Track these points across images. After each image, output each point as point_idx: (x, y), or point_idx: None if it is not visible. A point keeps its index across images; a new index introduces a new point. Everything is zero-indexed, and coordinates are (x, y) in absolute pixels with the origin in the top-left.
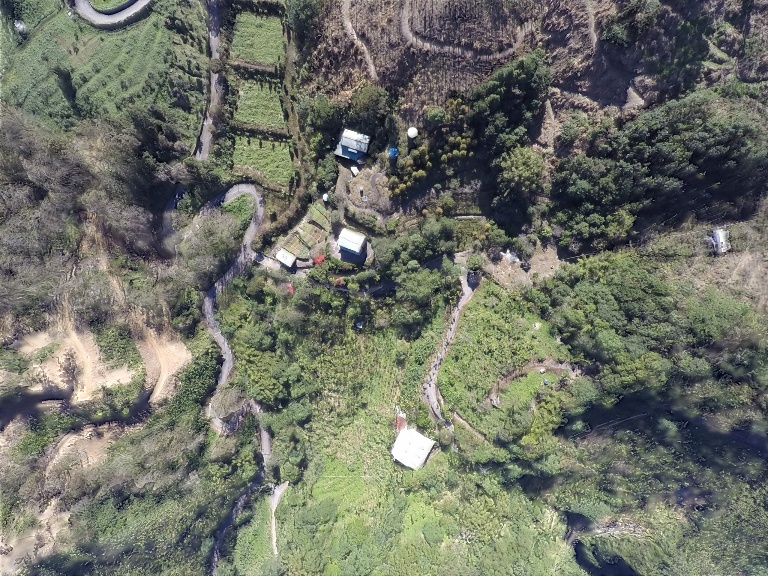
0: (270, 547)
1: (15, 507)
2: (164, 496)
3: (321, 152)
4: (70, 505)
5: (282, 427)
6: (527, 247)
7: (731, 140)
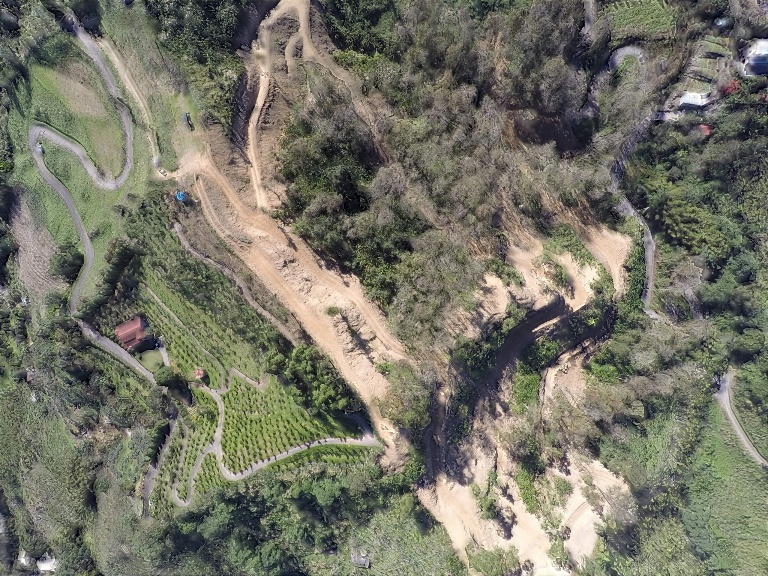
0: (745, 452)
1: (536, 483)
2: (663, 410)
3: None
4: (591, 454)
5: (735, 285)
6: None
7: None
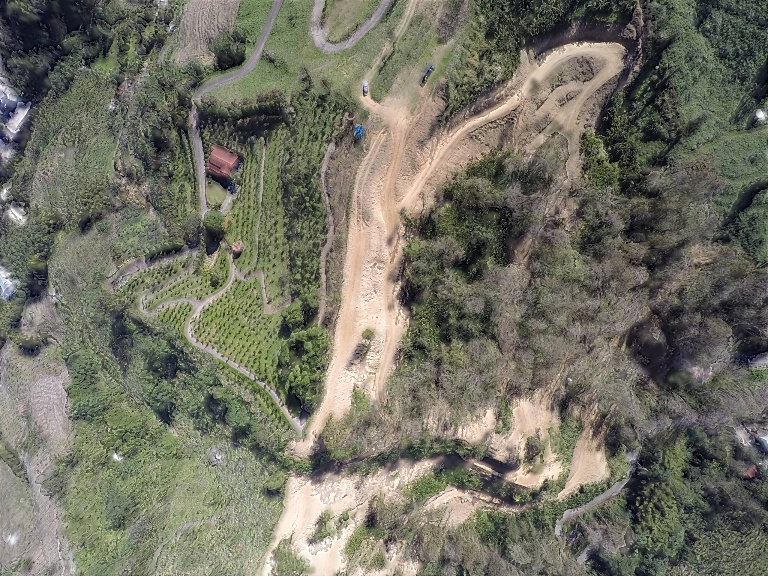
0: None
1: (365, 541)
2: None
3: None
4: (416, 563)
5: (631, 572)
6: None
7: None
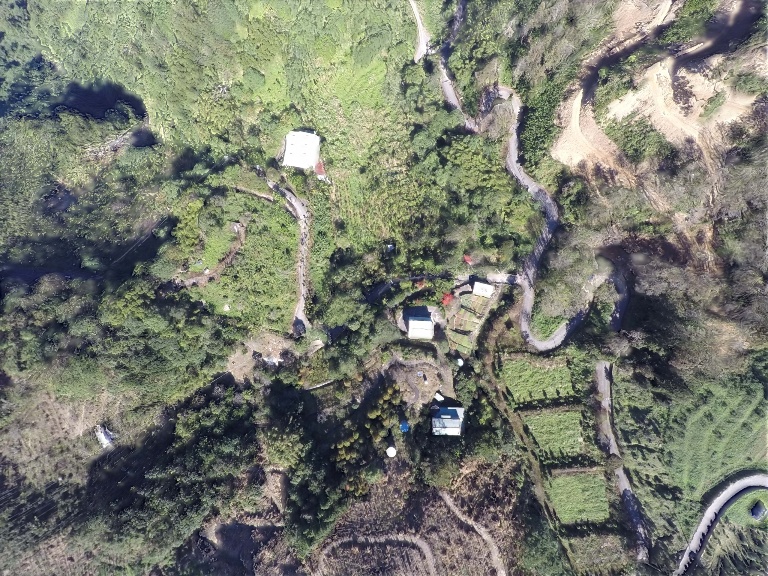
0: None
1: None
2: None
3: (478, 406)
4: None
5: (435, 118)
6: (260, 374)
7: (119, 523)
